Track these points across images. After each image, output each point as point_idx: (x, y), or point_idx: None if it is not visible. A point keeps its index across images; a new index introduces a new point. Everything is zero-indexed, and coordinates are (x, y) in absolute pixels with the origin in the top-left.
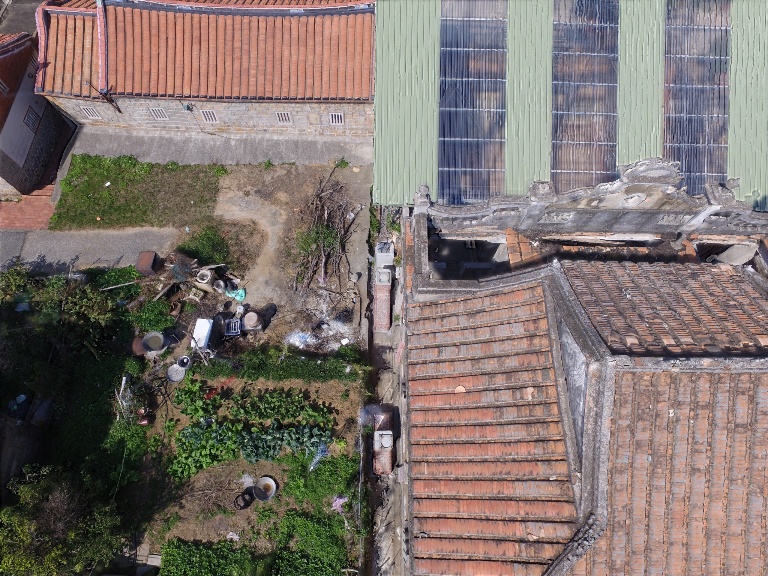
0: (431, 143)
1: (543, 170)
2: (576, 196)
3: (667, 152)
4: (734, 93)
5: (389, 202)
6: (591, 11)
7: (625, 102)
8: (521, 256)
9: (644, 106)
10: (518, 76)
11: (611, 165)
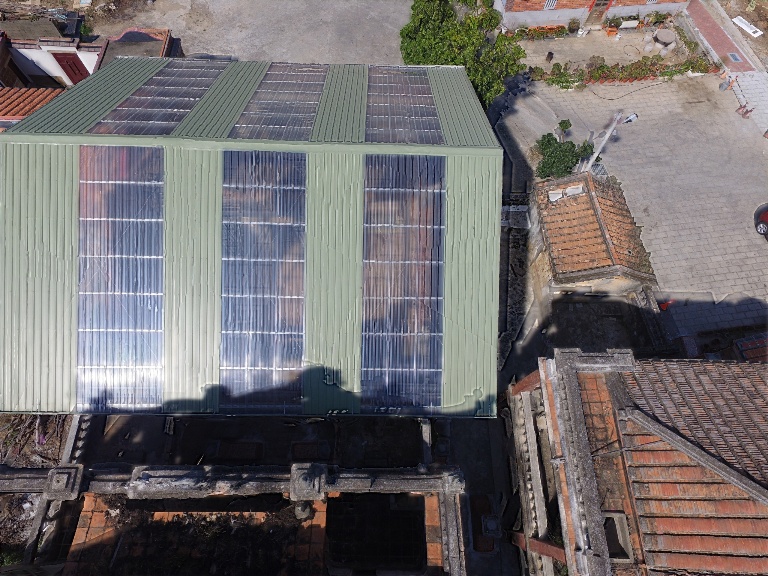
0: (68, 335)
1: (210, 367)
2: (104, 491)
3: (366, 343)
4: (450, 270)
5: (14, 409)
6: (271, 171)
7: (315, 282)
8: (86, 535)
9: (337, 287)
10: (178, 252)
11: (296, 360)
